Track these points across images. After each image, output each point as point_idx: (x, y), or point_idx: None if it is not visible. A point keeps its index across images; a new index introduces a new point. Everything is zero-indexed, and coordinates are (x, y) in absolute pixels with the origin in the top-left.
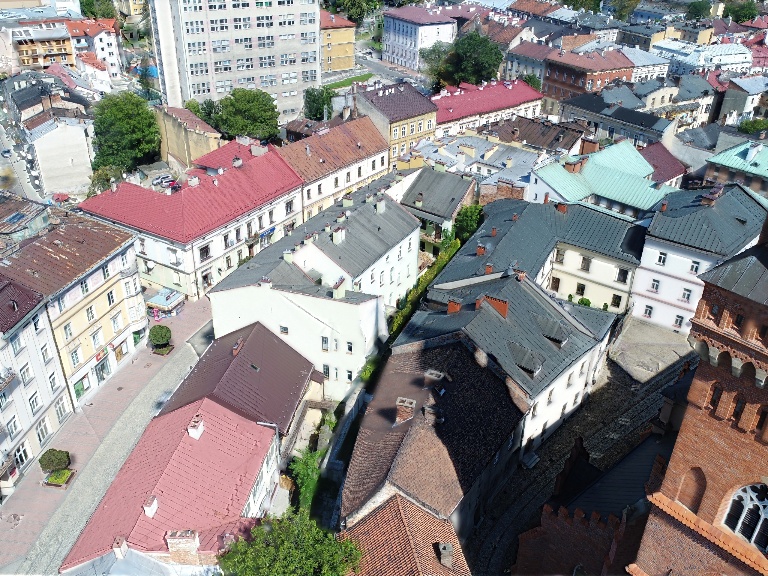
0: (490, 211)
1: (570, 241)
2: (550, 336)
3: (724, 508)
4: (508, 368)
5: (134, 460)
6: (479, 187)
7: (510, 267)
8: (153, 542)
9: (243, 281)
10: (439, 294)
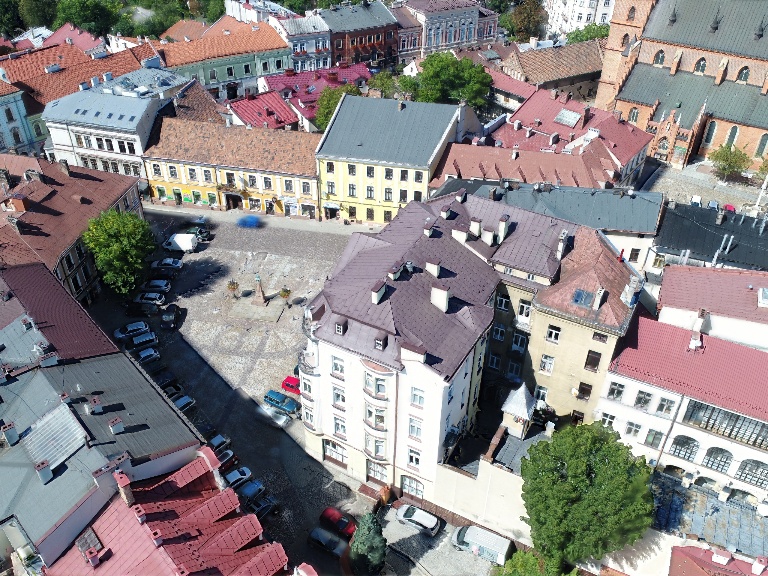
0: None
1: None
2: None
3: None
4: None
5: None
6: None
7: None
8: None
9: None
10: None
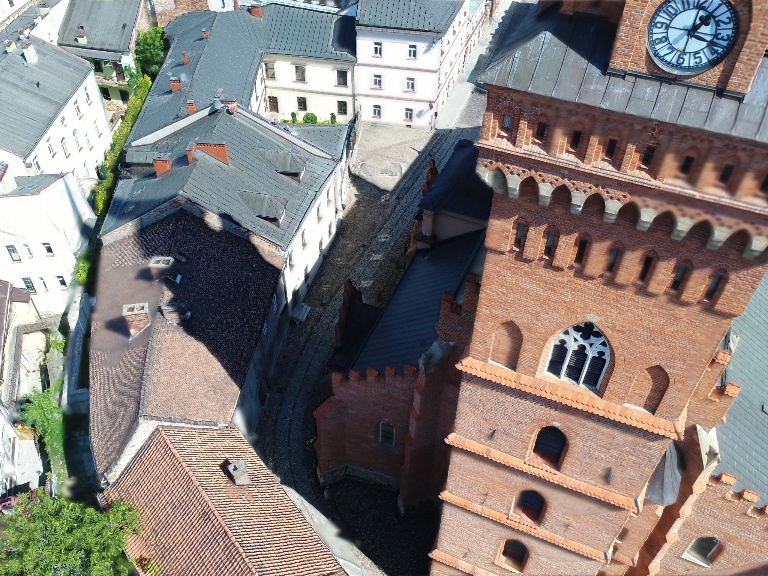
0: (174, 32)
1: (276, 50)
2: (285, 171)
3: (546, 357)
4: (248, 223)
5: None
6: (152, 4)
7: (216, 99)
8: None
9: None
10: (139, 154)
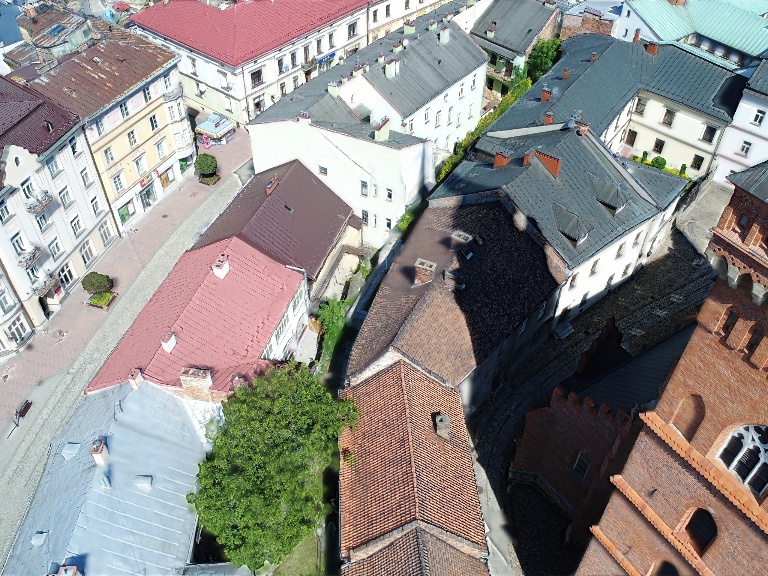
0: (568, 48)
1: (654, 89)
2: (604, 201)
3: (721, 442)
4: (549, 234)
5: (162, 293)
6: (563, 17)
7: (572, 118)
8: (169, 376)
9: (283, 114)
10: (489, 144)
